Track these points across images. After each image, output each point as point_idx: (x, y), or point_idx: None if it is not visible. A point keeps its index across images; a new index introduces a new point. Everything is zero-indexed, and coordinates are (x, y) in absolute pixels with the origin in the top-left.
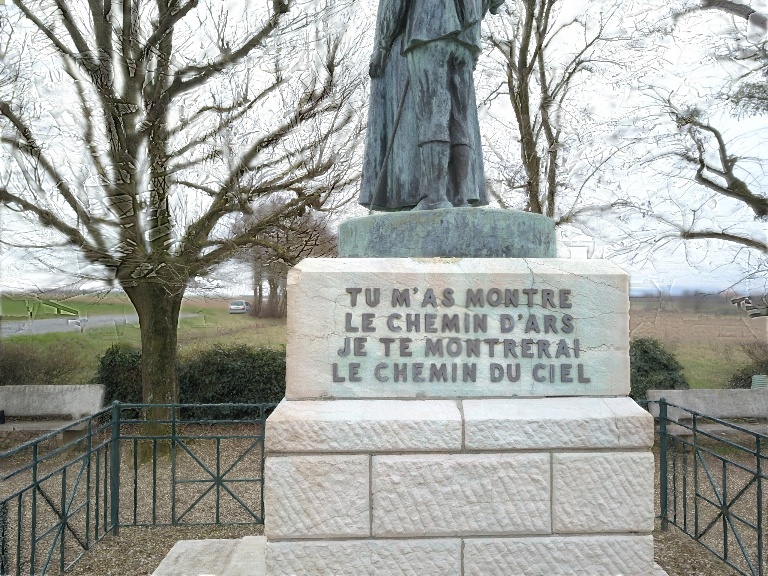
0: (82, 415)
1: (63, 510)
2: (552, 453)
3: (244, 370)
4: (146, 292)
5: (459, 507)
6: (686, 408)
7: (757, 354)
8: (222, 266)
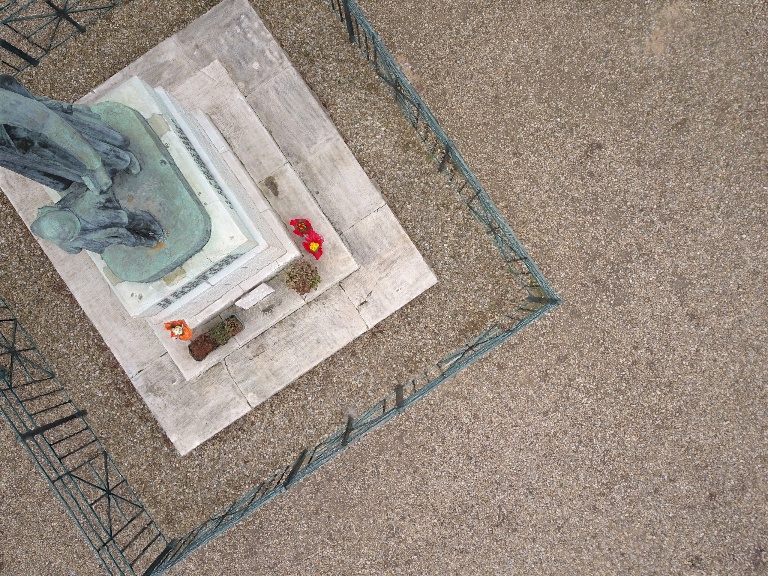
0: None
1: None
2: None
3: None
4: None
5: None
6: None
7: None
8: None
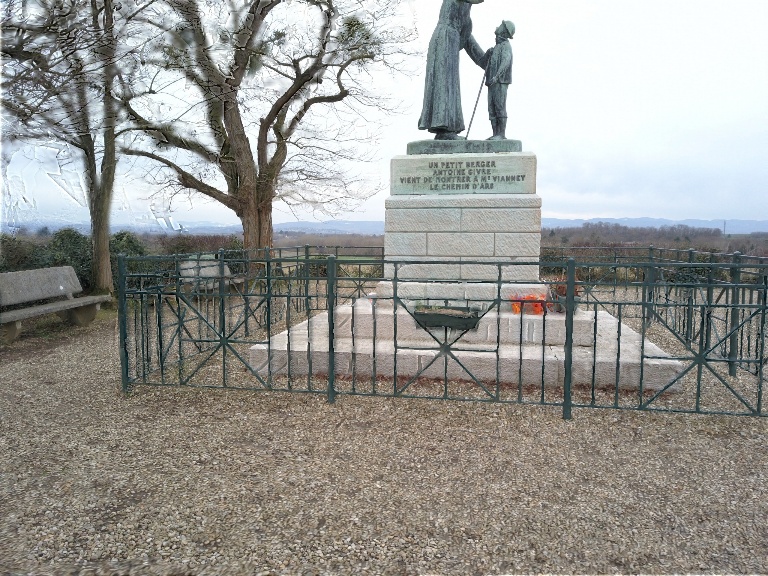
0: None
1: None
2: None
3: None
4: None
5: None
6: None
7: (167, 244)
8: None
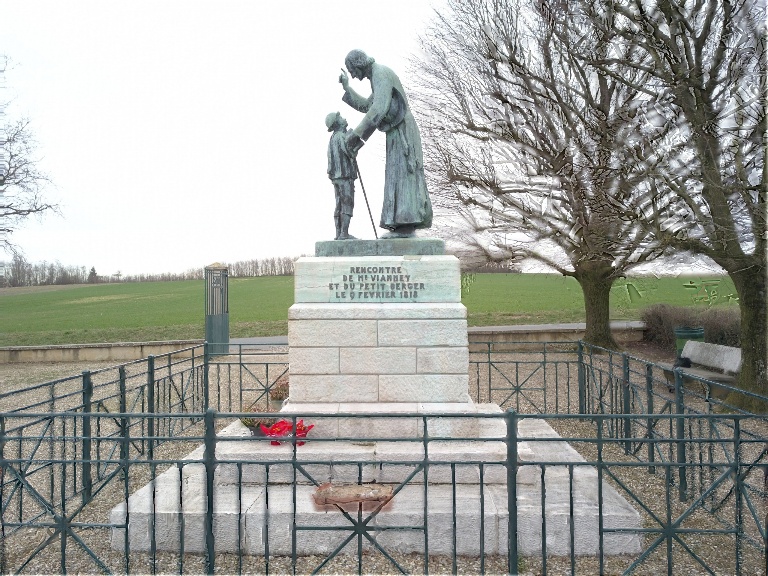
0: (729, 371)
1: None
2: None
3: None
4: (736, 269)
5: None
6: None
7: None
8: None
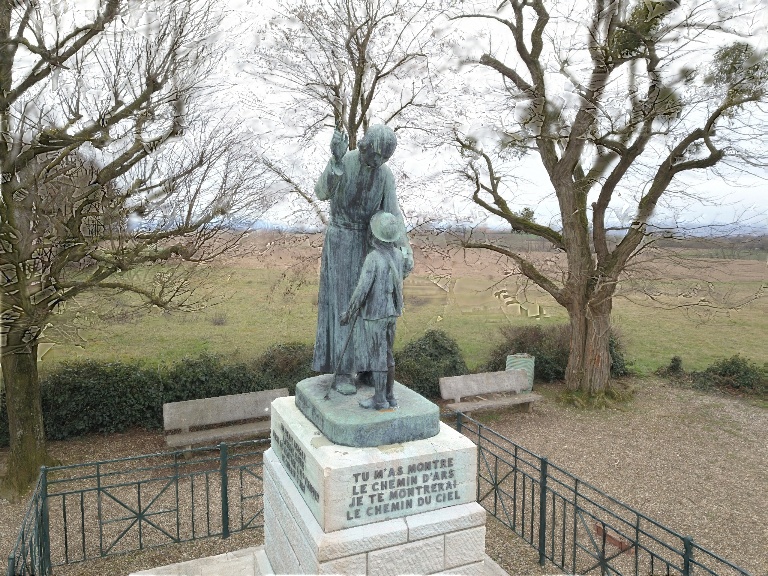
0: None
1: (32, 572)
2: (445, 535)
3: (99, 387)
4: None
5: (406, 568)
6: (465, 389)
7: (510, 334)
8: (78, 298)
